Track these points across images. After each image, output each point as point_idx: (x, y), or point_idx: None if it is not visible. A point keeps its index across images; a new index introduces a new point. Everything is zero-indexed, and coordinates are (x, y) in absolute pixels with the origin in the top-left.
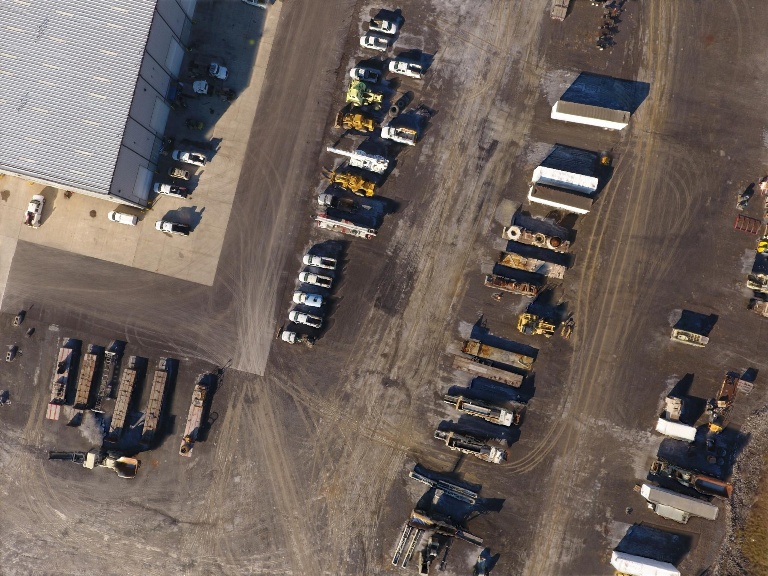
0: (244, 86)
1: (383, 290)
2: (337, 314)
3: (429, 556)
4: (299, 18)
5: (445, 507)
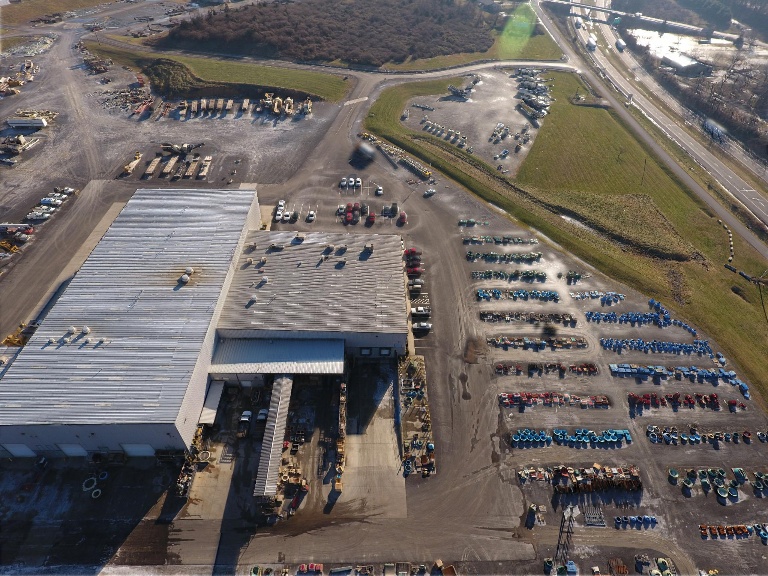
0: (67, 281)
1: (2, 214)
2: (38, 203)
3: (15, 140)
4: (7, 323)
5: (2, 156)
